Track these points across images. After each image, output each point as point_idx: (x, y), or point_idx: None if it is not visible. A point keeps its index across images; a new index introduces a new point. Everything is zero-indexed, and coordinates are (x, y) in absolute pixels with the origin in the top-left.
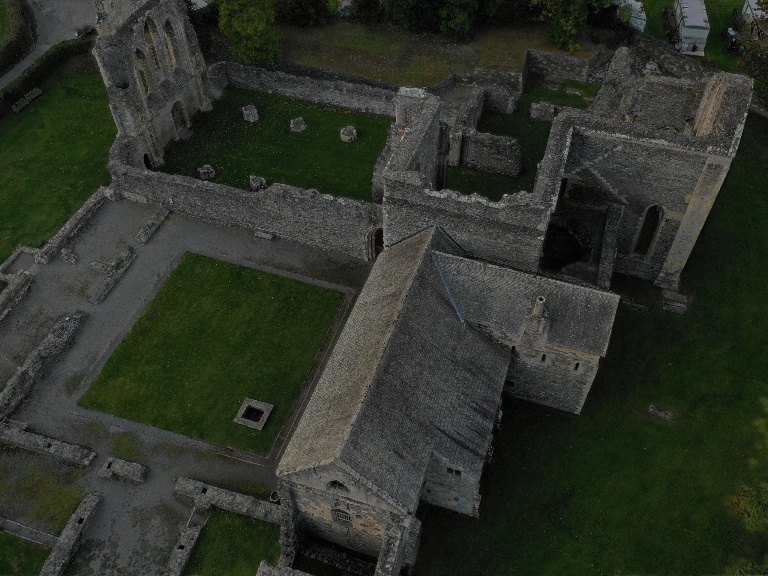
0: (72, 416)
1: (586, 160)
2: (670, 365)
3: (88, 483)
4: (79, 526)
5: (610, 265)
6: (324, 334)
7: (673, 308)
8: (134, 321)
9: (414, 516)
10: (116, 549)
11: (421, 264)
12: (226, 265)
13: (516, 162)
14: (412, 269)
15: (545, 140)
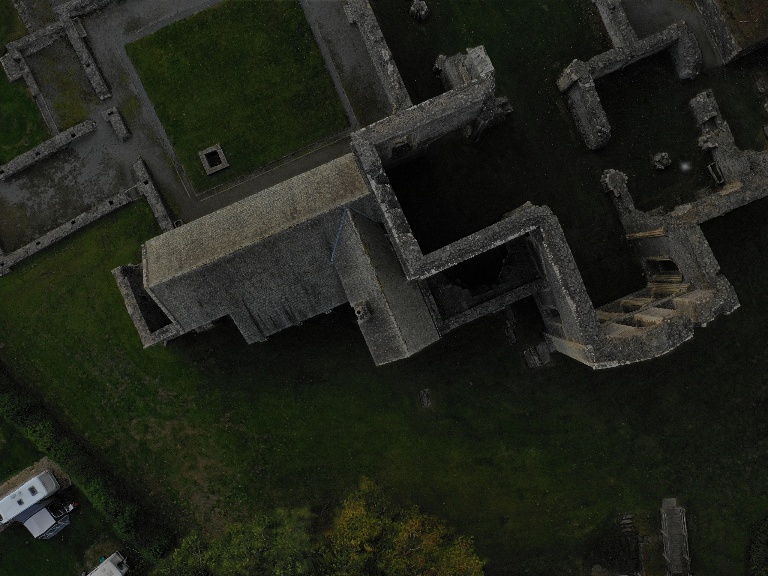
0: (116, 53)
1: (541, 246)
2: (471, 384)
3: (95, 112)
4: (71, 138)
5: (480, 315)
6: (306, 145)
7: (530, 358)
8: (204, 8)
9: (209, 322)
10: (83, 168)
11: (326, 213)
12: (301, 16)
13: (595, 143)
14: (319, 209)
15: (664, 138)
